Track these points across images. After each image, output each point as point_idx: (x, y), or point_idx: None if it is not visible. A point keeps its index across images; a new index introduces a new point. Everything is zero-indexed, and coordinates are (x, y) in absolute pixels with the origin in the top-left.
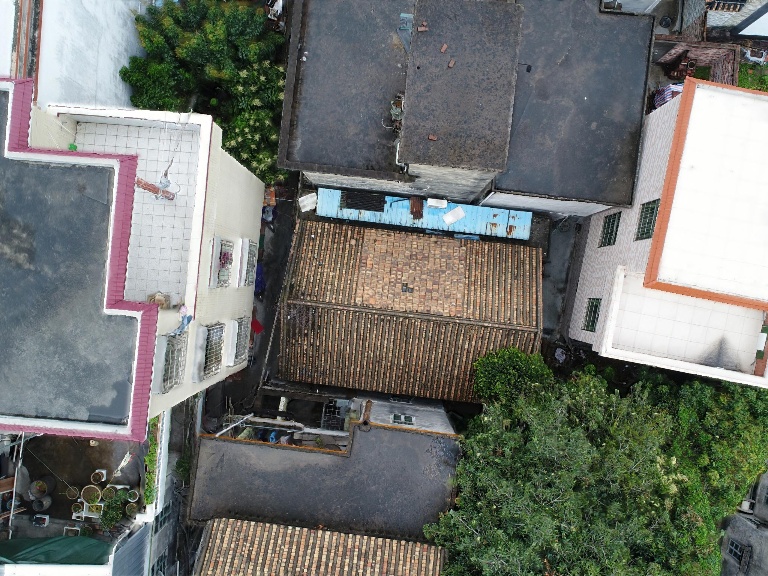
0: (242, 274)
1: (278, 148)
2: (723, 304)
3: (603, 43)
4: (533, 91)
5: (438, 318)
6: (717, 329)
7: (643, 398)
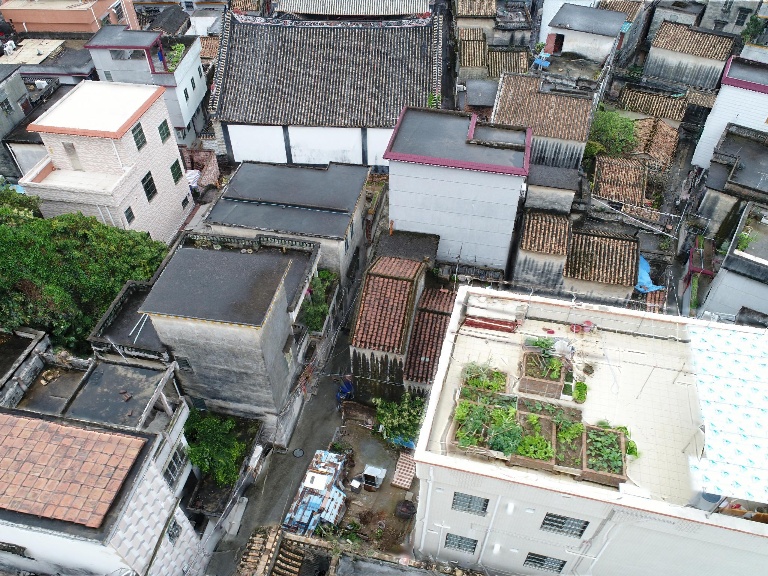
0: None
1: None
2: (110, 178)
3: None
4: None
5: None
6: (102, 186)
7: None
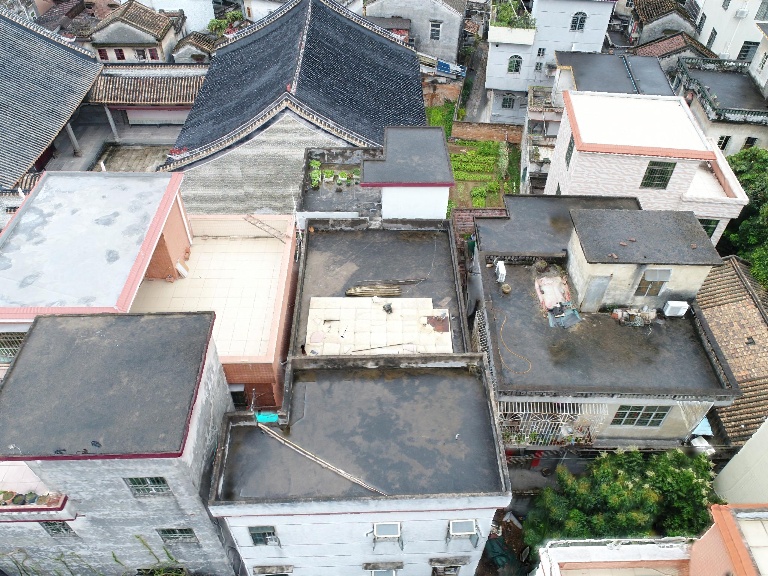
0: None
1: (725, 396)
2: None
3: (531, 216)
4: None
5: (765, 313)
6: None
7: (760, 184)
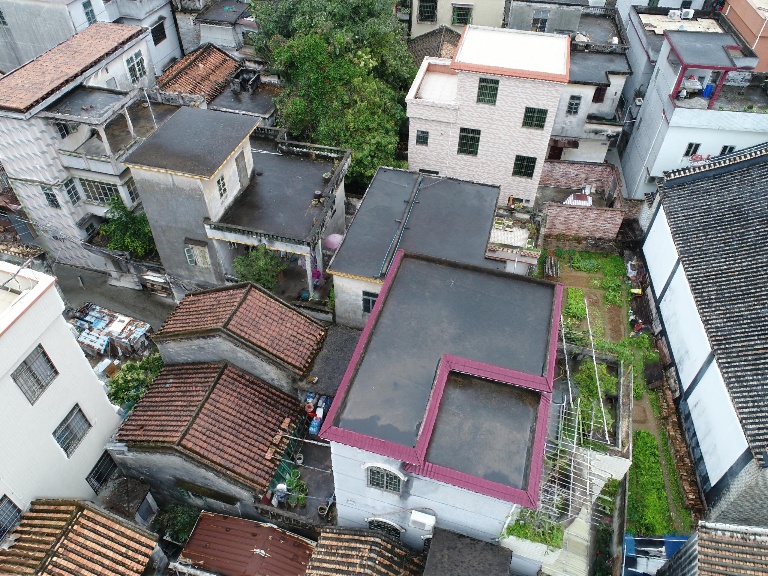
0: (458, 5)
1: None
2: None
3: None
4: None
5: None
6: None
7: None
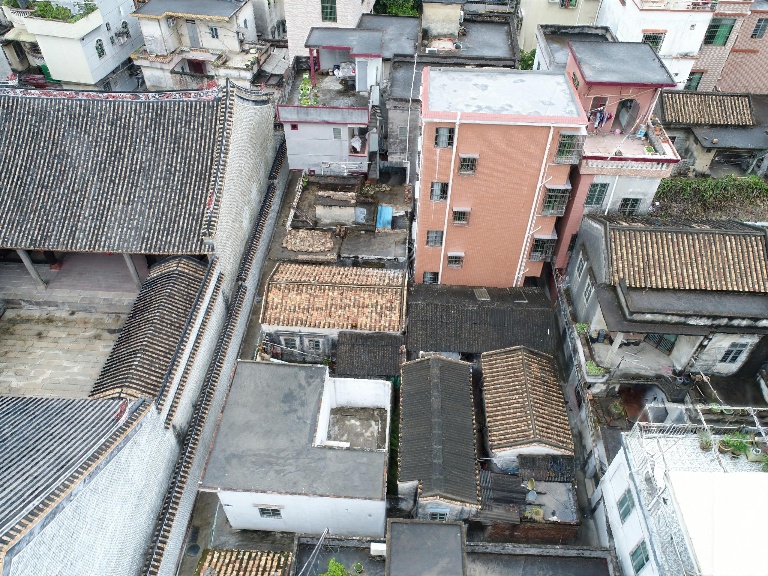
0: None
1: None
2: None
3: None
4: (406, 34)
5: None
6: None
7: None
